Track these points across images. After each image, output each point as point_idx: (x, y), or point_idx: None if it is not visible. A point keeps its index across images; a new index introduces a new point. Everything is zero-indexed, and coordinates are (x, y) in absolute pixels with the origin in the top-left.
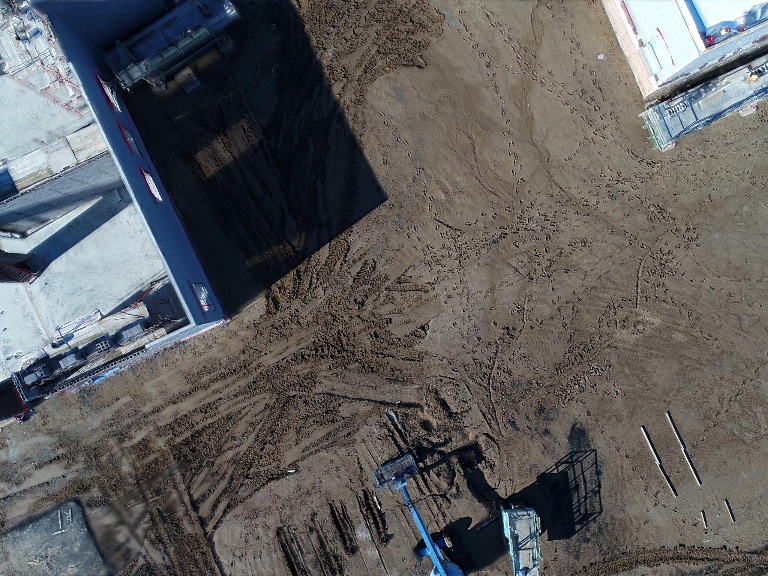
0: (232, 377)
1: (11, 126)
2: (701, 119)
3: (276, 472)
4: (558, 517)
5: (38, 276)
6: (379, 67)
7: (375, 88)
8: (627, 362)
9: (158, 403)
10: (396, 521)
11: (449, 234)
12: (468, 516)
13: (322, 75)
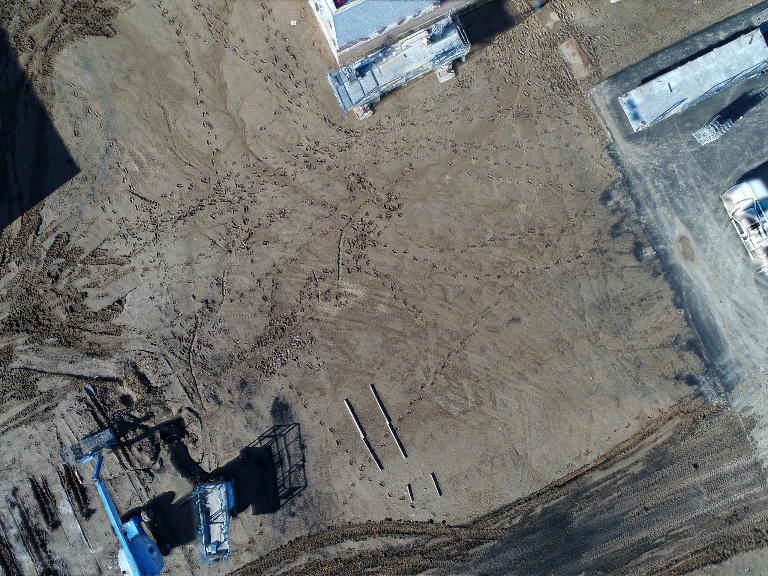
0: None
1: None
2: (382, 85)
3: None
4: (262, 491)
5: None
6: (67, 37)
7: (63, 59)
8: (330, 335)
9: None
10: (98, 496)
11: (144, 206)
12: (171, 490)
13: (9, 46)
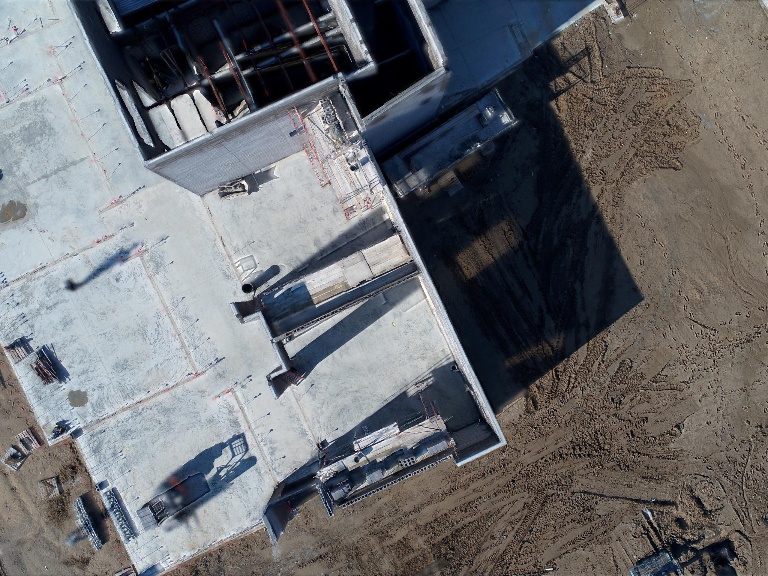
0: (491, 476)
1: (279, 230)
2: None
3: (533, 570)
4: None
5: (305, 378)
6: (637, 170)
7: (633, 190)
8: None
9: (419, 502)
10: None
11: (704, 333)
12: None
13: (581, 178)
